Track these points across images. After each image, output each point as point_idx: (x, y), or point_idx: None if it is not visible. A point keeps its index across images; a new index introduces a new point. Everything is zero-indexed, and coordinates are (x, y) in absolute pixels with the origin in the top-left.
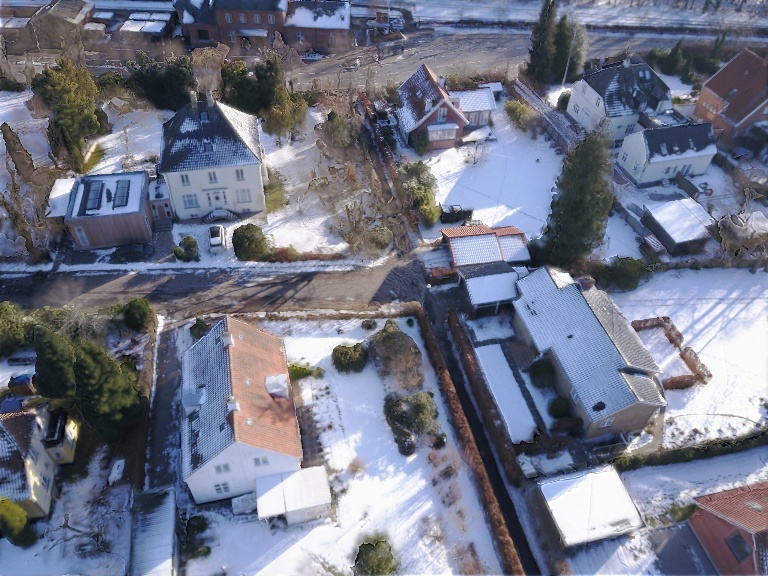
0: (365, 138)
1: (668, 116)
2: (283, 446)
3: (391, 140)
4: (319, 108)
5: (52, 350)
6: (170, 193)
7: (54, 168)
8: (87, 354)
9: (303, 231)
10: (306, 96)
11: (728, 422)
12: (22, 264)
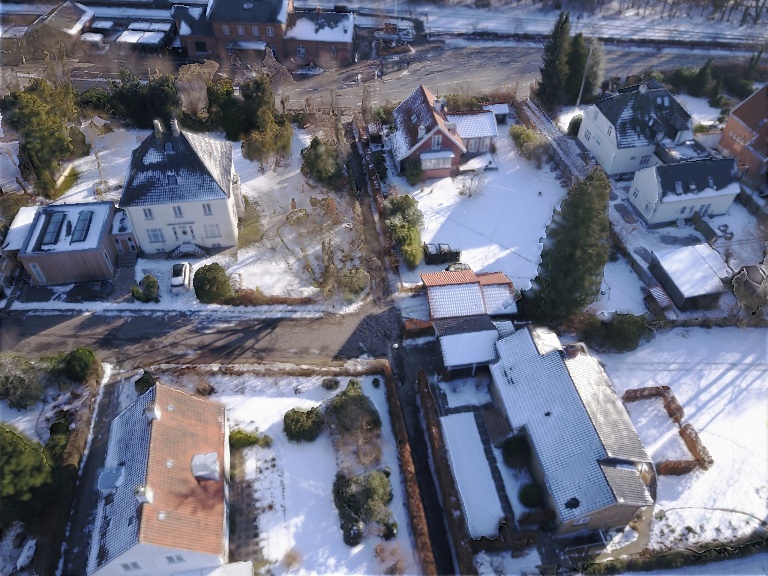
0: (355, 164)
1: (688, 147)
2: (201, 542)
3: (381, 168)
4: (309, 130)
5: None
6: (133, 227)
7: (23, 194)
8: None
9: (274, 270)
10: (296, 117)
11: (729, 519)
12: None
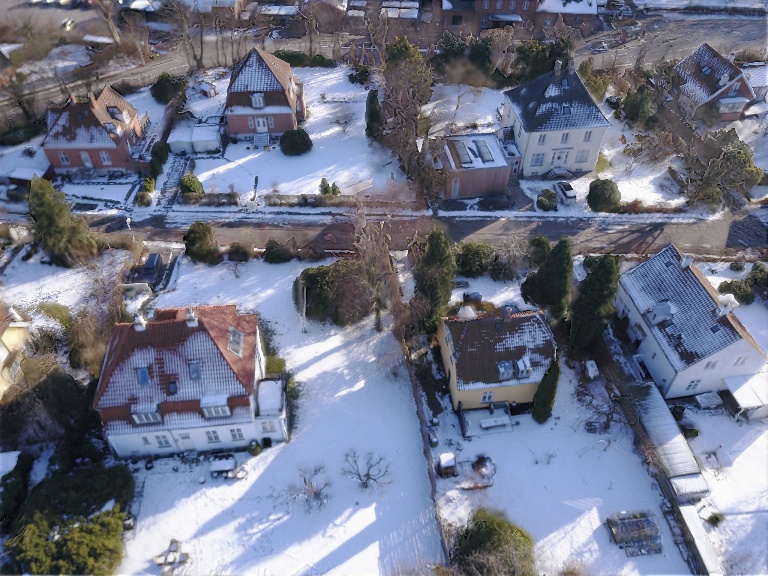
0: None
1: None
2: None
3: (681, 112)
4: None
5: (567, 260)
6: (525, 151)
7: None
8: None
9: (637, 188)
10: None
11: None
12: (408, 209)
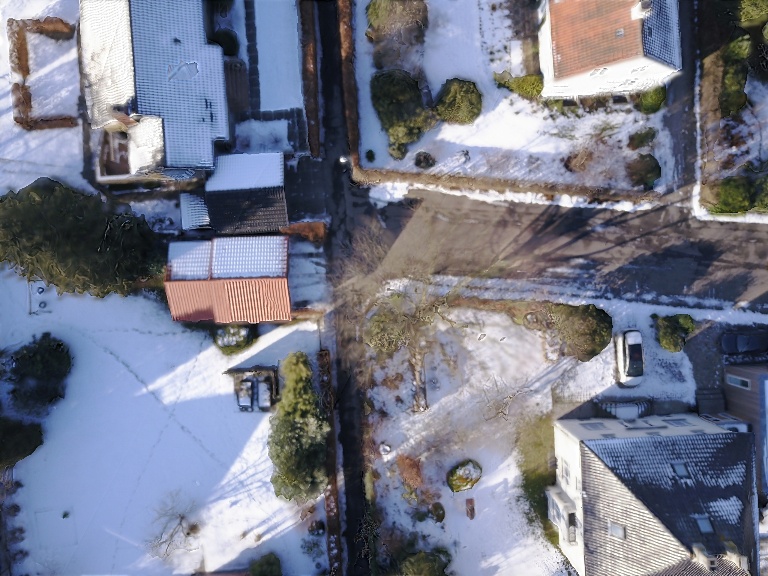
0: None
1: None
2: None
3: None
4: None
5: None
6: None
7: None
8: None
9: (498, 364)
10: None
11: None
12: None
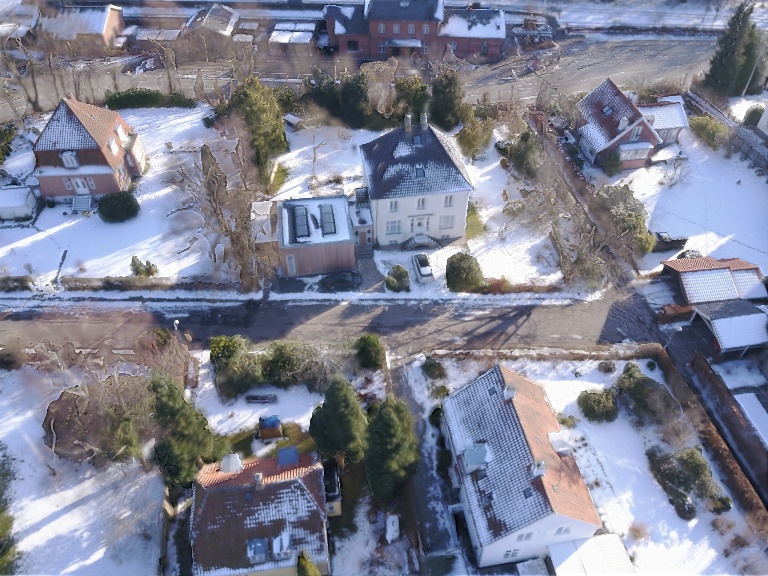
0: None
1: None
2: (586, 514)
3: (578, 160)
4: None
5: (345, 403)
6: (376, 219)
7: None
8: (394, 412)
9: (509, 260)
10: (478, 111)
11: None
12: (233, 292)
